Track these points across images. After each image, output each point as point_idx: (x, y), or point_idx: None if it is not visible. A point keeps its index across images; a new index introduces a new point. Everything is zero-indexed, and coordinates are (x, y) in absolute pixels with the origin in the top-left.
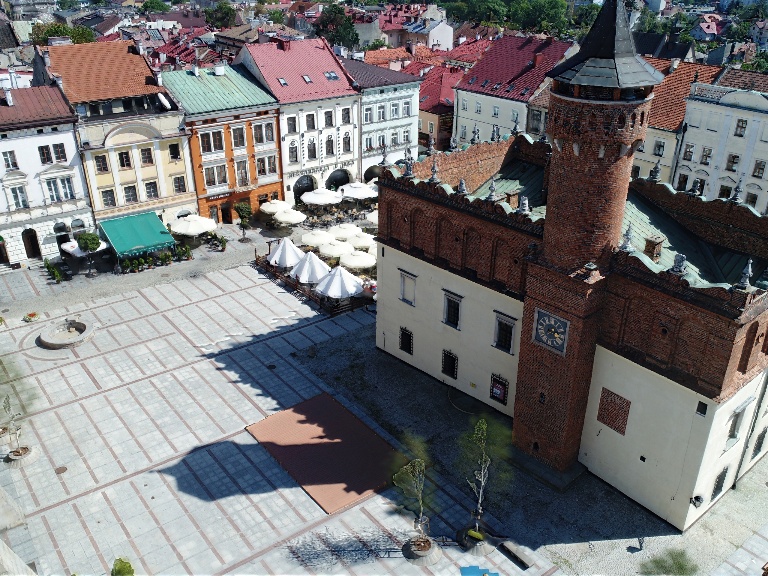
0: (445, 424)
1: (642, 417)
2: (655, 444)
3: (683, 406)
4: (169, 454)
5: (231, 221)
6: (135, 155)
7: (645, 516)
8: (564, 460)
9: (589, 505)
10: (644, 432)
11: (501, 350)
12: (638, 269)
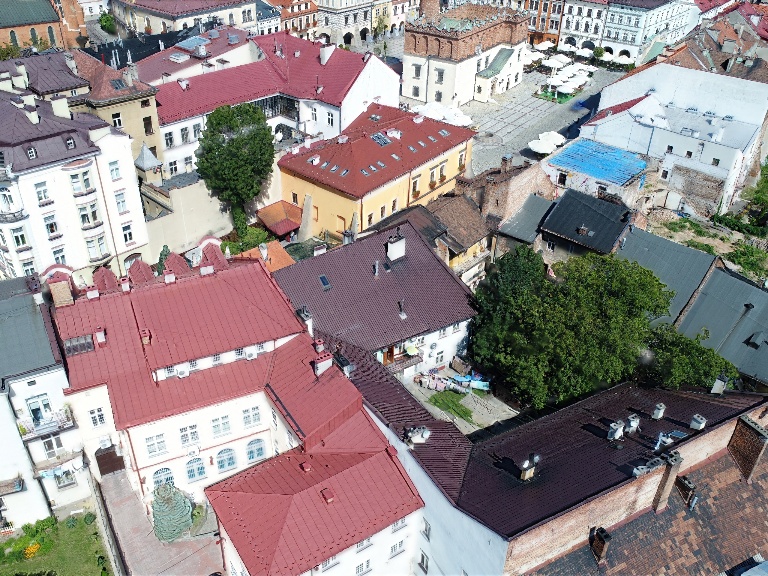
0: None
1: None
2: None
3: None
4: (390, 55)
5: (533, 44)
6: (506, 1)
7: None
8: None
9: None
10: None
11: None
12: None
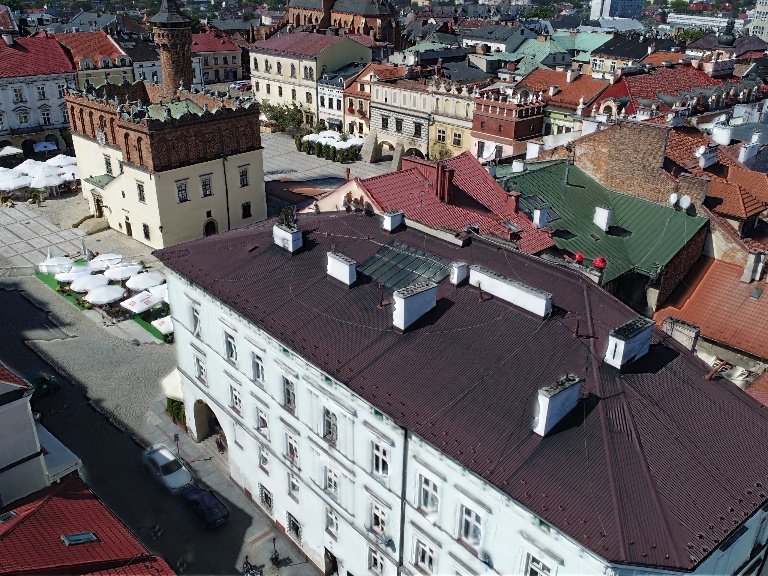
0: None
1: None
2: None
3: None
4: None
5: None
6: None
7: None
8: None
9: None
10: None
11: None
12: None
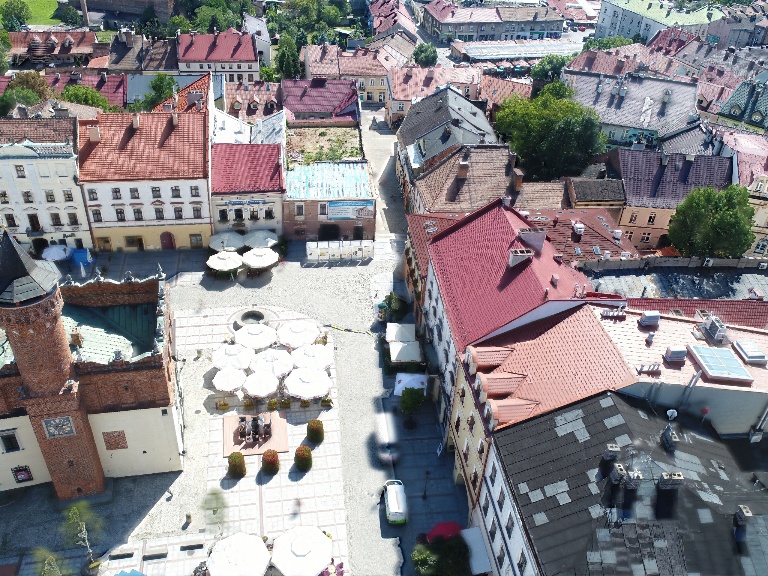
0: (2, 524)
1: (134, 434)
2: (148, 442)
3: (154, 417)
4: None
5: None
6: None
7: (161, 477)
8: (102, 484)
9: (131, 496)
10: (139, 440)
11: (12, 452)
12: (95, 367)
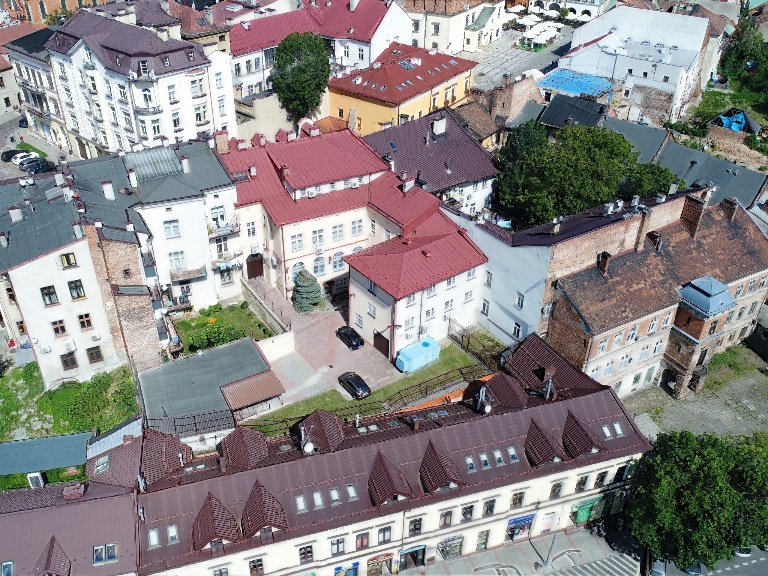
0: None
1: None
2: None
3: None
4: None
5: None
6: None
7: None
8: None
9: None
10: None
11: None
12: None
